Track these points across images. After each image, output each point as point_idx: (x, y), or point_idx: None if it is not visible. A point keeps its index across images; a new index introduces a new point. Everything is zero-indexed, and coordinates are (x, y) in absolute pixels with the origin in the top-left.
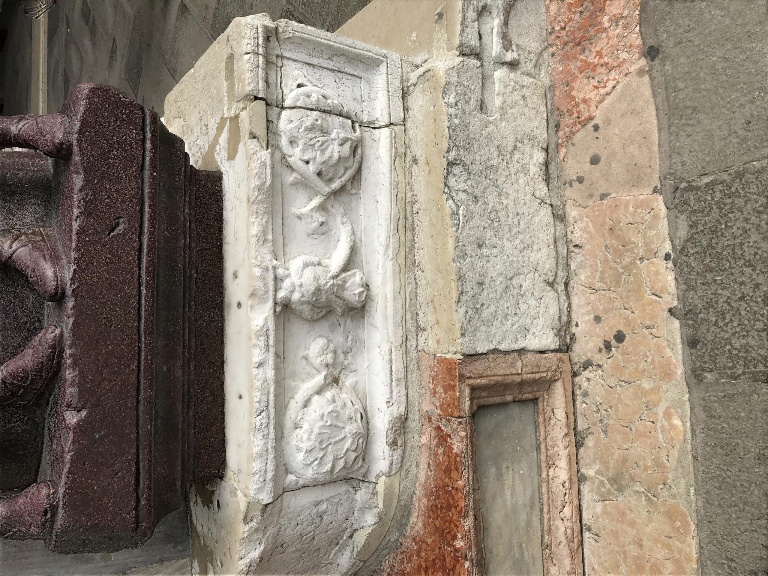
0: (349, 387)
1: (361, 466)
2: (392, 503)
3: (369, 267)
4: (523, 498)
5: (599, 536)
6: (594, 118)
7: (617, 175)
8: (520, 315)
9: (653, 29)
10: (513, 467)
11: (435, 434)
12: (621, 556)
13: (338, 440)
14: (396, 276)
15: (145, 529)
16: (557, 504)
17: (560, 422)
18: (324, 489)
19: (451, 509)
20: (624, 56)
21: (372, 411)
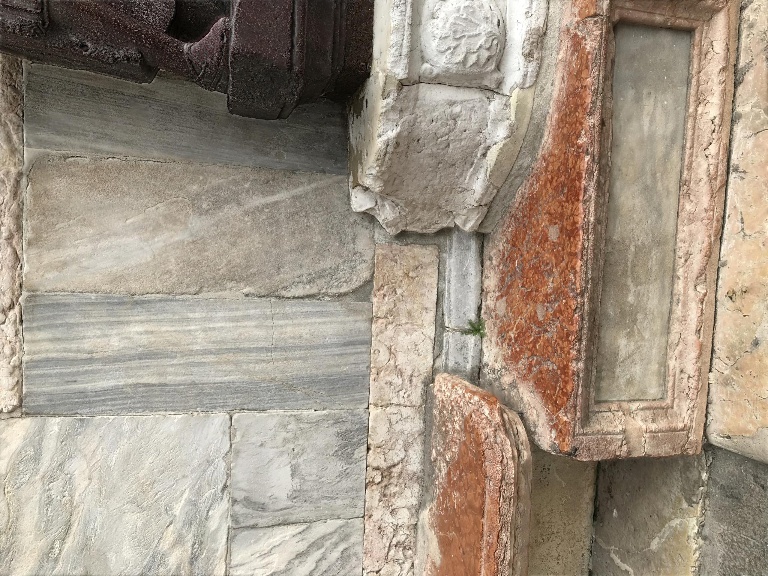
0: None
1: (495, 70)
2: (524, 118)
3: None
4: (664, 129)
5: (746, 172)
6: None
7: None
8: None
9: None
10: (656, 95)
11: (571, 43)
12: (766, 185)
13: (472, 35)
14: None
15: (298, 72)
16: (703, 140)
17: (718, 54)
18: (459, 91)
19: (578, 108)
20: None
21: (511, 23)
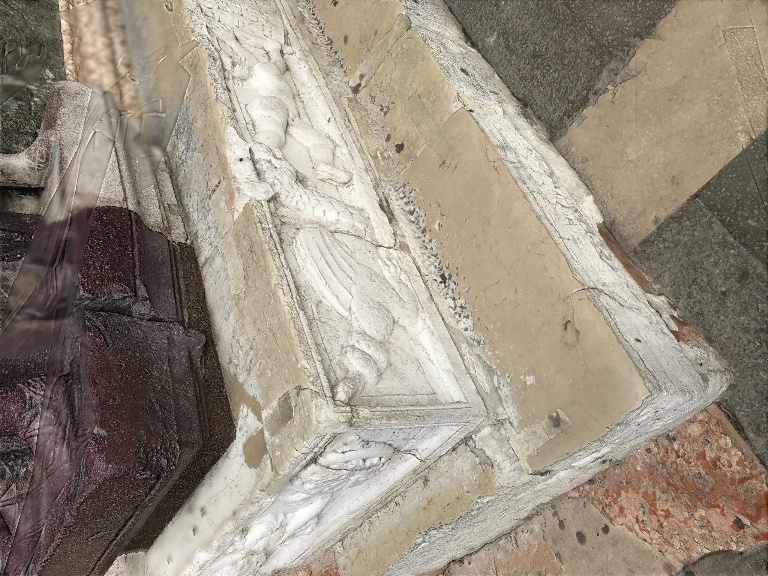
0: (262, 553)
1: None
2: None
3: (328, 512)
4: None
5: None
6: (612, 524)
7: (578, 569)
8: (424, 567)
9: (710, 574)
10: None
11: None
12: None
13: None
14: (345, 524)
15: None
16: None
17: None
18: None
19: None
20: (675, 544)
21: (272, 558)
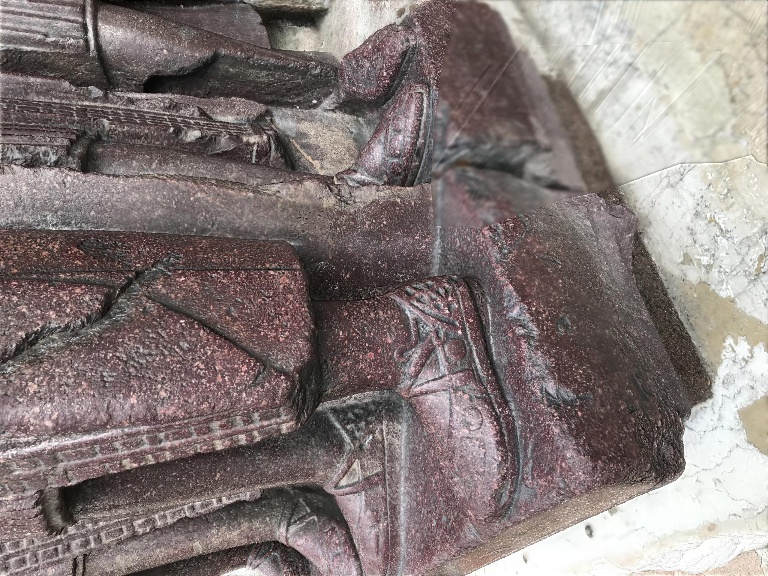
0: None
1: None
2: None
3: None
4: None
5: None
6: None
7: None
8: None
9: None
10: None
11: None
12: None
13: None
14: None
15: None
16: None
17: None
18: None
19: None
20: None
21: None
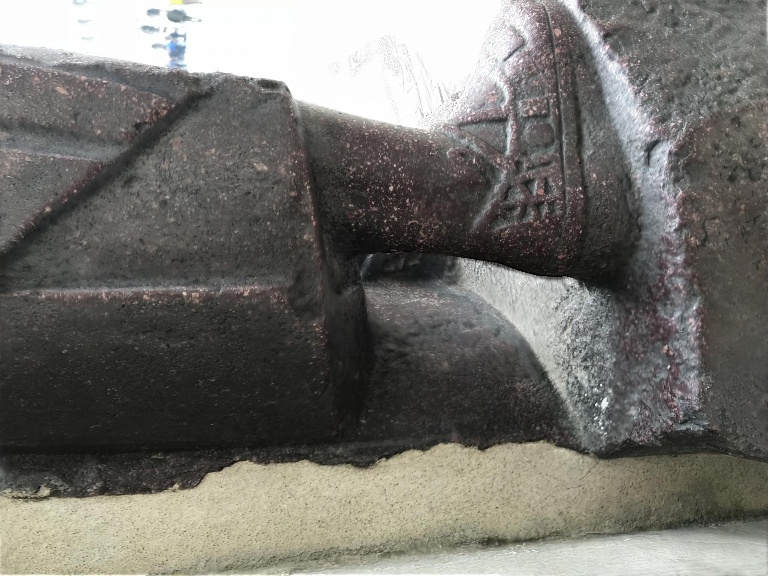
0: None
1: None
2: None
3: None
4: None
5: None
6: None
7: None
8: None
9: None
10: None
11: None
12: None
13: None
14: None
15: None
16: None
17: None
18: None
19: None
20: None
21: None
